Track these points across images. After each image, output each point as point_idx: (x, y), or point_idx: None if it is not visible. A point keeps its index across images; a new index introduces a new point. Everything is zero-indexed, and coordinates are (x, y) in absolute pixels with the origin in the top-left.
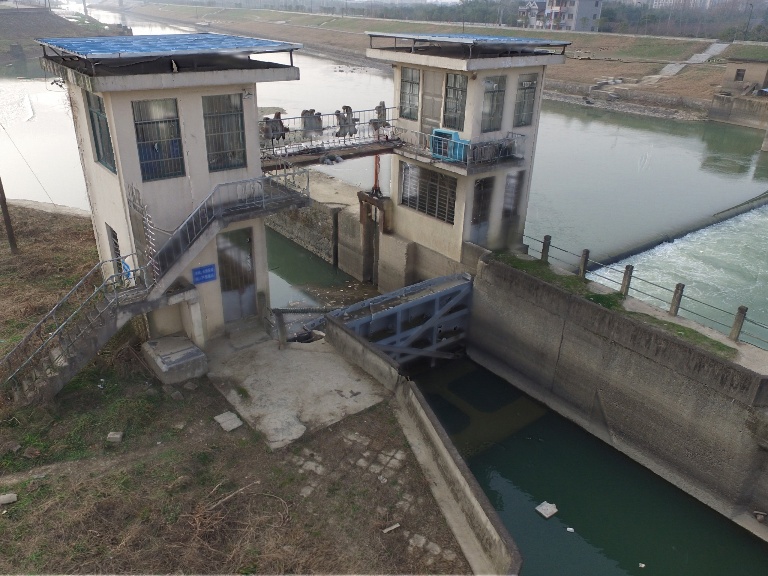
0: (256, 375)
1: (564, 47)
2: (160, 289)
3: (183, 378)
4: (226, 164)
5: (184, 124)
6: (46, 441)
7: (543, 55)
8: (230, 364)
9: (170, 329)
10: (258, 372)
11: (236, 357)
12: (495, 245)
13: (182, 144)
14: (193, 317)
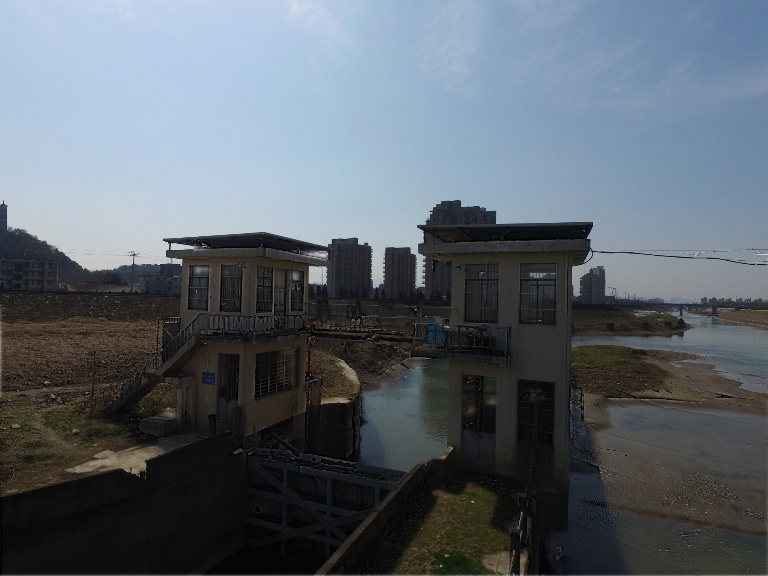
0: (162, 447)
1: (585, 231)
2: (162, 370)
3: (149, 432)
4: (230, 308)
5: (211, 280)
6: None
7: (542, 240)
8: (176, 439)
9: (186, 408)
10: None
11: None
12: (509, 472)
13: (209, 291)
14: (178, 398)
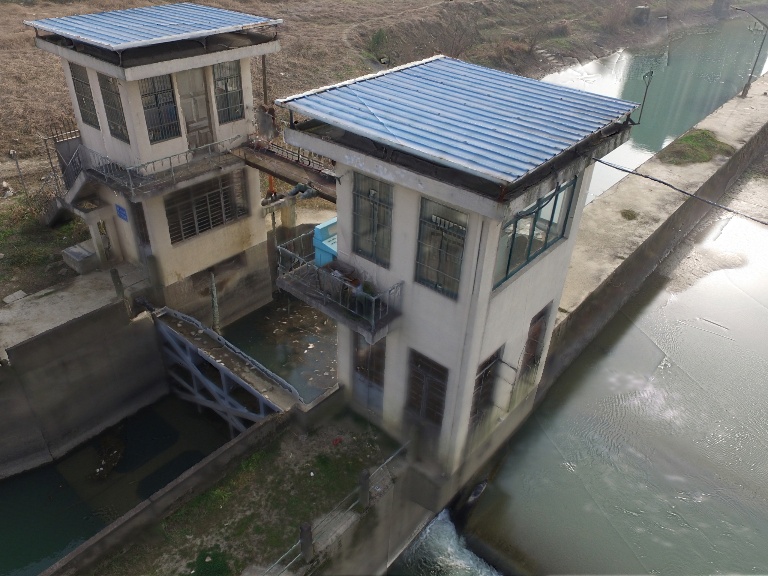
0: (71, 295)
1: None
2: None
3: None
4: None
5: None
6: (6, 237)
7: (439, 180)
8: (93, 281)
9: None
10: (76, 295)
11: (104, 281)
12: (395, 432)
13: None
14: None
